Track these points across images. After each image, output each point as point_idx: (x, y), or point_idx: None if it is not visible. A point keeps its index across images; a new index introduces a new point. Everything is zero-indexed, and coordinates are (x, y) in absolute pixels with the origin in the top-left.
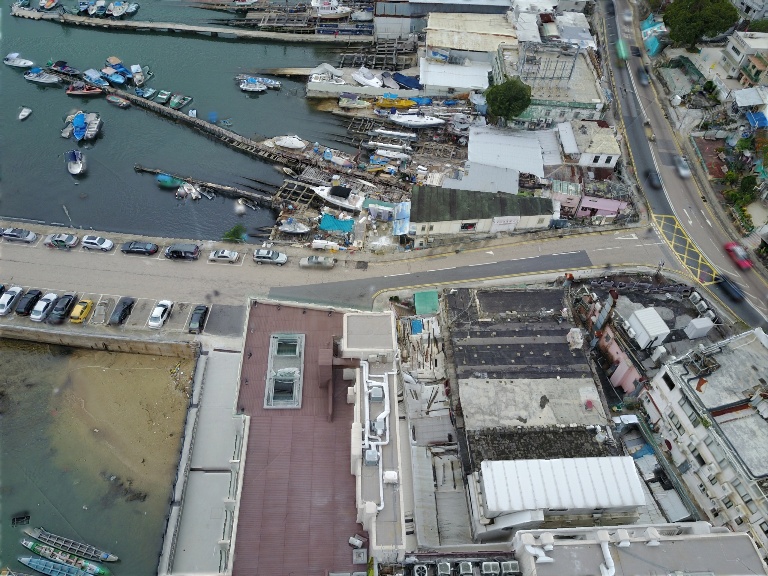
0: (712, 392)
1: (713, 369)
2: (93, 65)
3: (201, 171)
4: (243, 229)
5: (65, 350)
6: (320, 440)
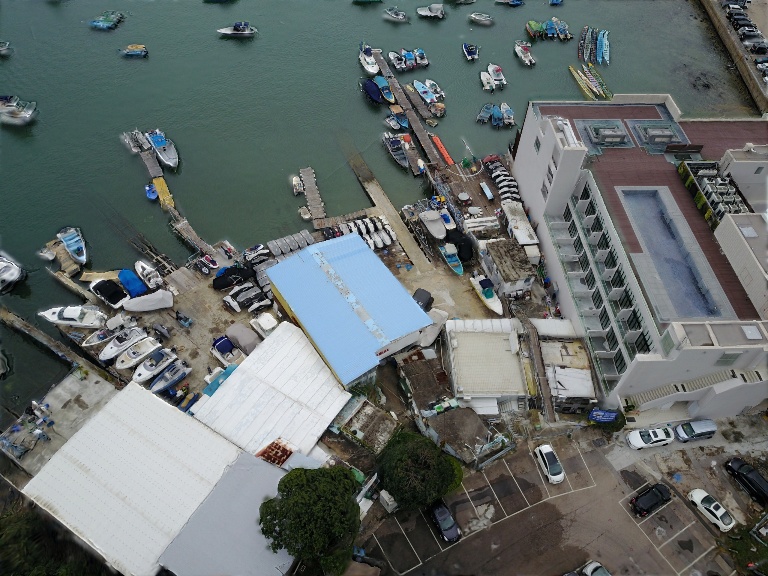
0: None
1: None
2: None
3: None
4: None
5: (751, 104)
6: None
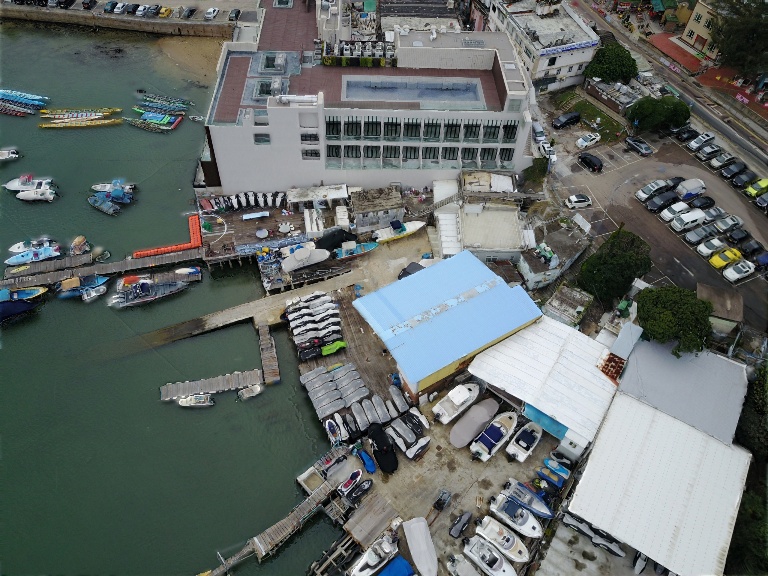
0: (514, 8)
1: (518, 1)
2: None
3: None
4: None
5: (155, 36)
6: (302, 17)
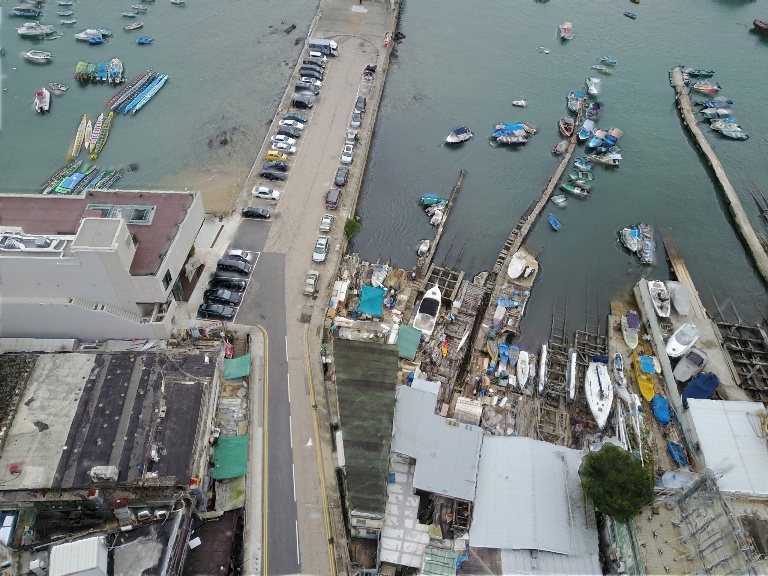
0: None
1: None
2: (601, 122)
3: (470, 213)
4: (355, 227)
5: None
6: None
